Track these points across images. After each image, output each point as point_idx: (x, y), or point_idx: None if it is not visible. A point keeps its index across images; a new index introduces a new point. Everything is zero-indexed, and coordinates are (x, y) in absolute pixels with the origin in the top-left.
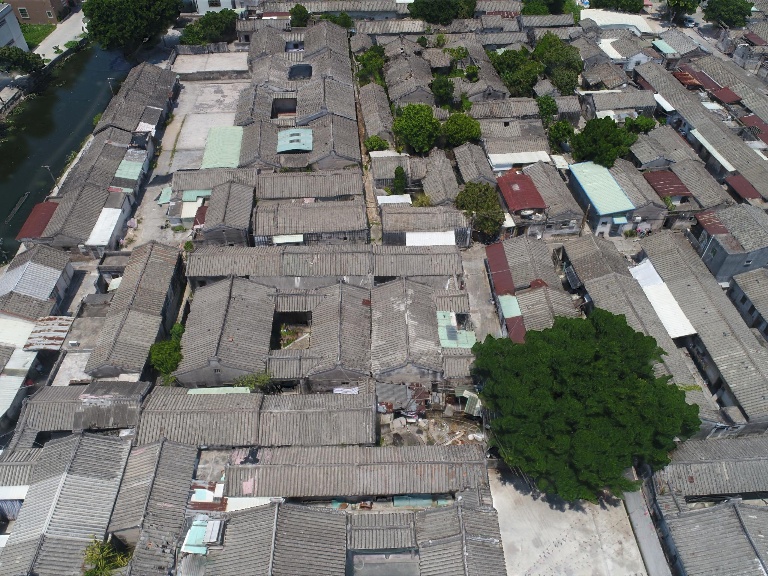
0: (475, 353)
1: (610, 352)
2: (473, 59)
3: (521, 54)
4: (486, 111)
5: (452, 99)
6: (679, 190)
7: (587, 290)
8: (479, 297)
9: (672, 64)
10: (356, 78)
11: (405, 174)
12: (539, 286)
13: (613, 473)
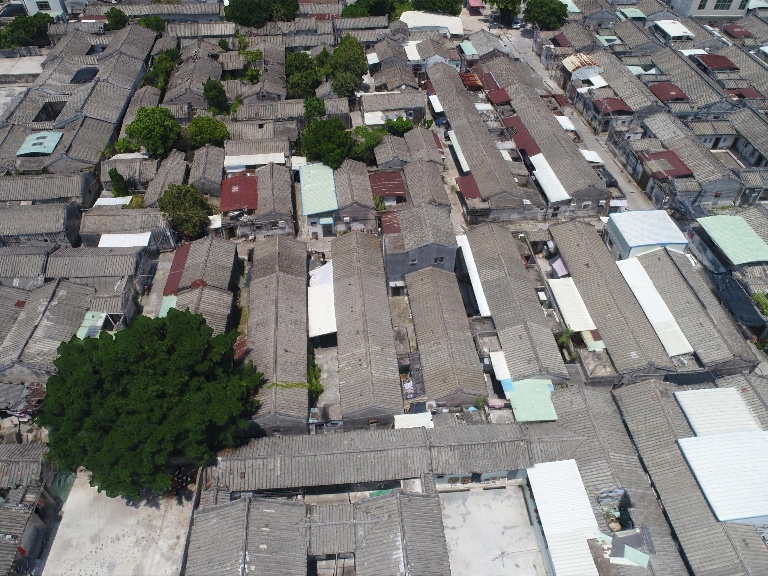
0: (59, 353)
1: (161, 351)
2: (263, 61)
3: (320, 56)
4: (251, 113)
5: (226, 101)
6: (394, 190)
7: (250, 290)
8: (162, 297)
9: (474, 65)
10: (142, 81)
11: (132, 176)
12: (197, 286)
13: (142, 469)
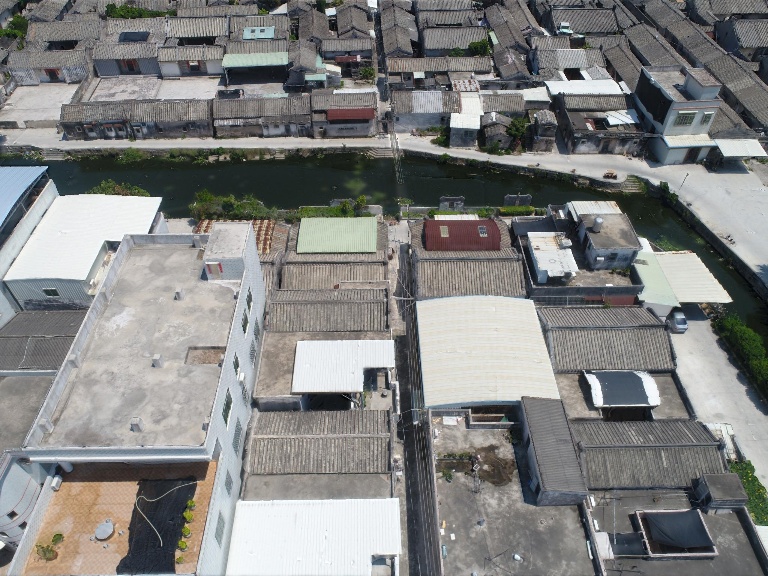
0: None
1: None
2: None
3: None
4: None
5: None
6: None
7: None
8: None
9: None
10: None
11: (309, 4)
12: None
13: None
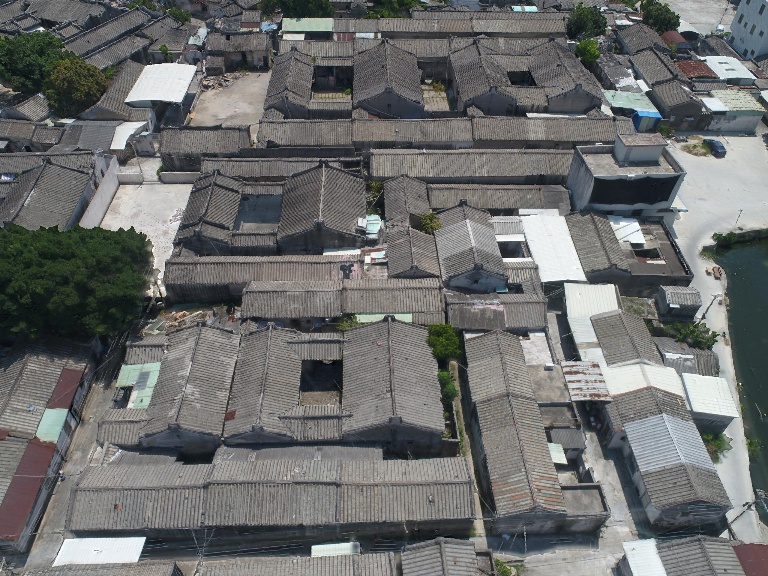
0: None
1: None
2: None
3: None
4: None
5: None
6: None
7: None
8: None
9: None
10: None
11: None
12: None
13: None
